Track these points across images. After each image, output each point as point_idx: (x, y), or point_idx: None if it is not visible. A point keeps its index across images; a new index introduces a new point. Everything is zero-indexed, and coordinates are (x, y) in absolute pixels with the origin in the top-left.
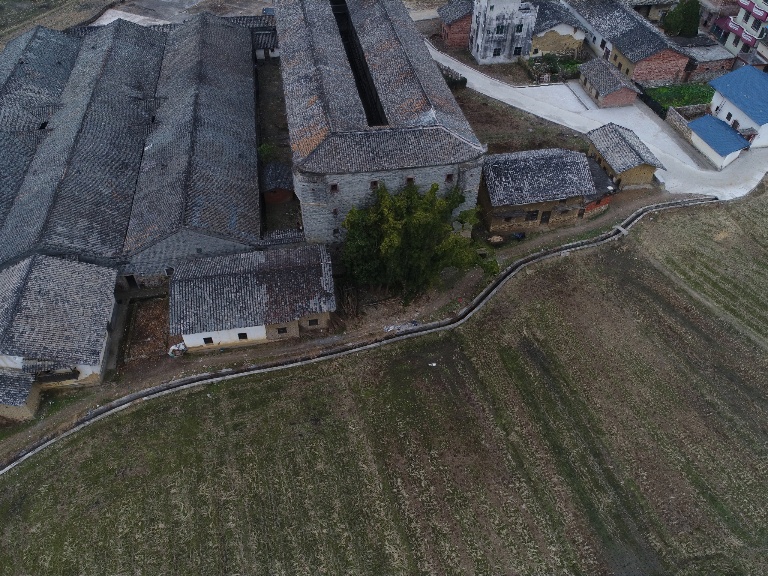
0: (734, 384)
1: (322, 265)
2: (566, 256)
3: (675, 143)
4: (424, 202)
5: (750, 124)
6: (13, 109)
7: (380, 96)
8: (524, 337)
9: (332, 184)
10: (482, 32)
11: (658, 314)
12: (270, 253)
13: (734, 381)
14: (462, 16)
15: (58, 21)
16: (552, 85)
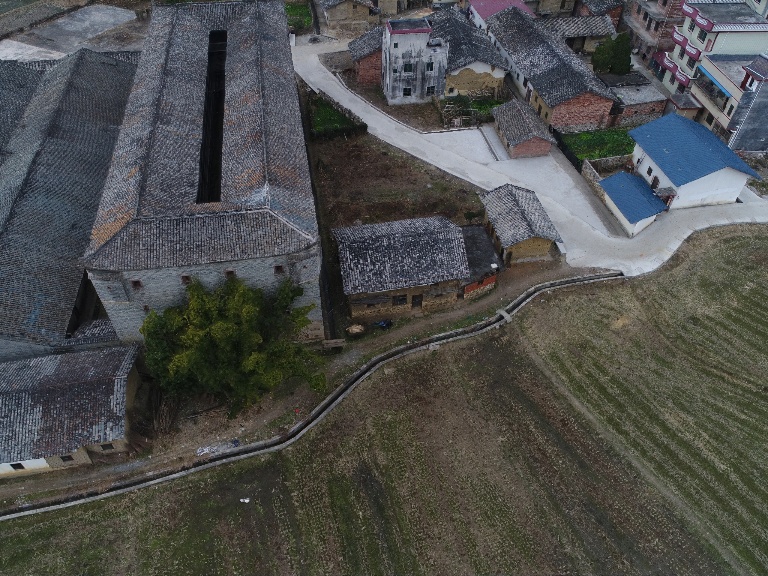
0: (603, 529)
1: (115, 380)
2: (435, 350)
3: (587, 202)
4: (233, 306)
5: (669, 183)
6: None
7: (223, 162)
8: (363, 461)
9: (133, 280)
10: (388, 71)
11: (528, 429)
12: (67, 359)
13: (604, 524)
14: (370, 52)
15: None
16: (464, 130)
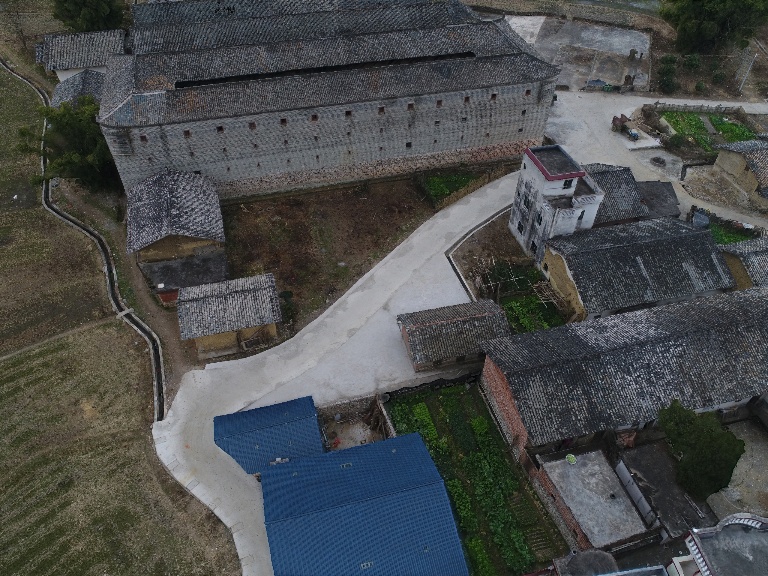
0: None
1: None
2: None
3: None
4: None
5: None
6: (300, 1)
7: None
8: None
9: None
10: None
11: None
12: None
13: None
14: None
15: (511, 5)
16: (465, 290)
